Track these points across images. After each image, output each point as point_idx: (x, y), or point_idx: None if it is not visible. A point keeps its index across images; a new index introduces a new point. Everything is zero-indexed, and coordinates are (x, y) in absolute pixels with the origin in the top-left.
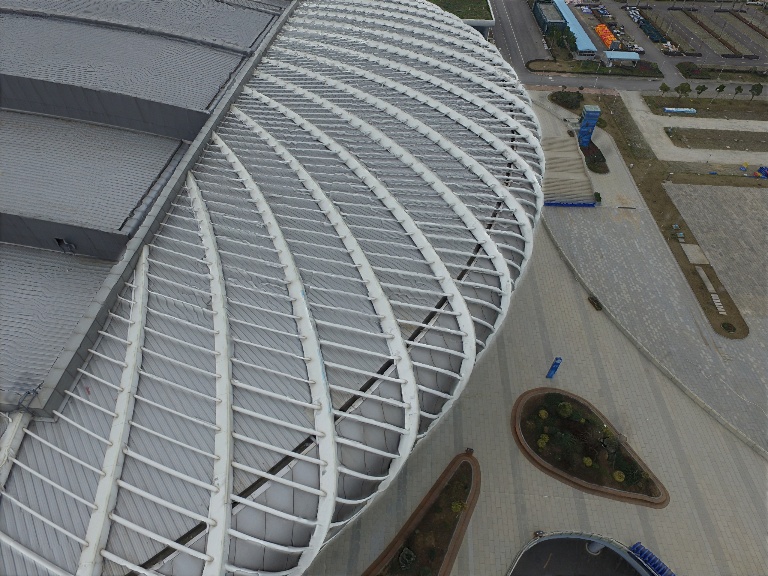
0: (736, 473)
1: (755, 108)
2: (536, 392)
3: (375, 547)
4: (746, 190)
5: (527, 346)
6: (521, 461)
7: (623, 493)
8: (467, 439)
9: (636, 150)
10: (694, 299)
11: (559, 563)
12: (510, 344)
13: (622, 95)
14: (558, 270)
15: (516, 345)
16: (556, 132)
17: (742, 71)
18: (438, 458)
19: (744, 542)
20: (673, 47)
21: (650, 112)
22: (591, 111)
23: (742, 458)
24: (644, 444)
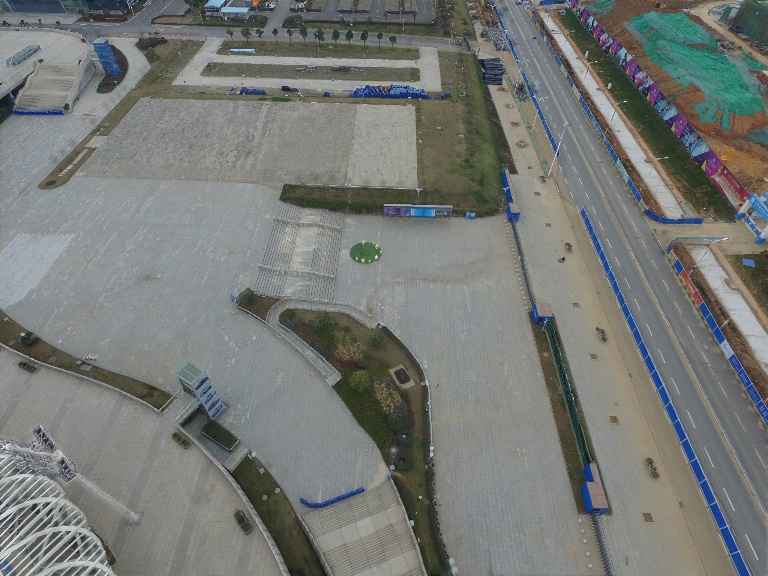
0: None
1: (308, 48)
2: None
3: None
4: (202, 101)
5: None
6: None
7: None
8: None
9: (161, 78)
10: (53, 168)
11: None
12: None
13: (208, 40)
14: None
15: None
16: (72, 61)
17: (334, 21)
18: None
19: None
20: (303, 5)
21: (215, 52)
22: (95, 43)
23: None
24: None
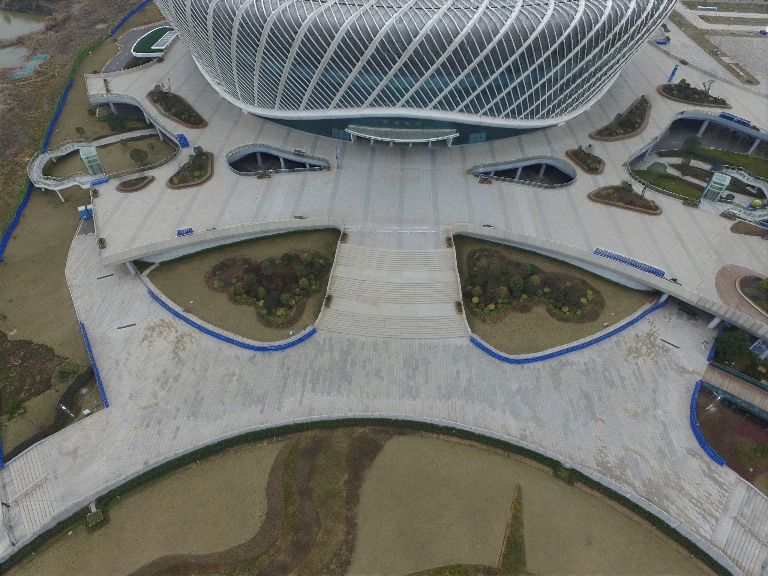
0: (760, 103)
1: (754, 7)
2: (666, 84)
3: (615, 115)
4: (753, 38)
5: (655, 74)
6: (666, 100)
7: (713, 105)
8: (640, 95)
9: (683, 24)
10: (730, 74)
11: (685, 138)
12: (647, 74)
13: None
14: (660, 54)
15: (650, 74)
16: None
17: None
18: (629, 99)
19: (765, 115)
20: None
21: (688, 9)
22: None
23: (762, 100)
24: (719, 96)
